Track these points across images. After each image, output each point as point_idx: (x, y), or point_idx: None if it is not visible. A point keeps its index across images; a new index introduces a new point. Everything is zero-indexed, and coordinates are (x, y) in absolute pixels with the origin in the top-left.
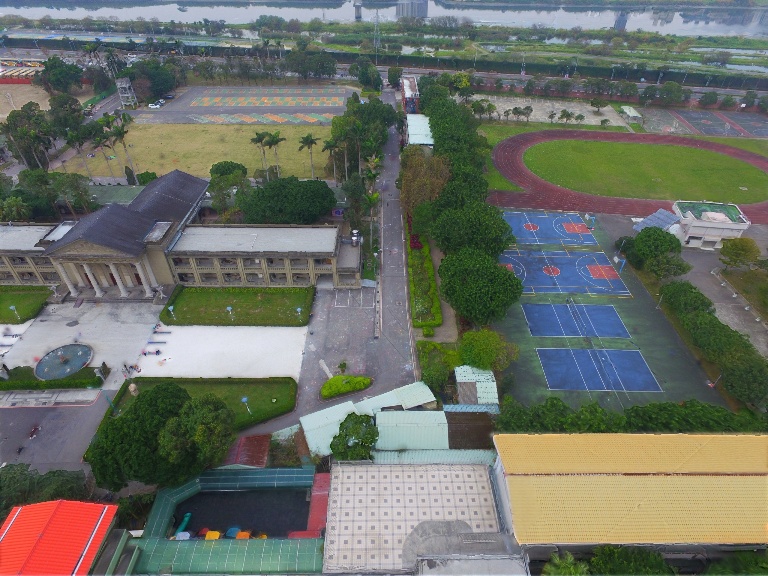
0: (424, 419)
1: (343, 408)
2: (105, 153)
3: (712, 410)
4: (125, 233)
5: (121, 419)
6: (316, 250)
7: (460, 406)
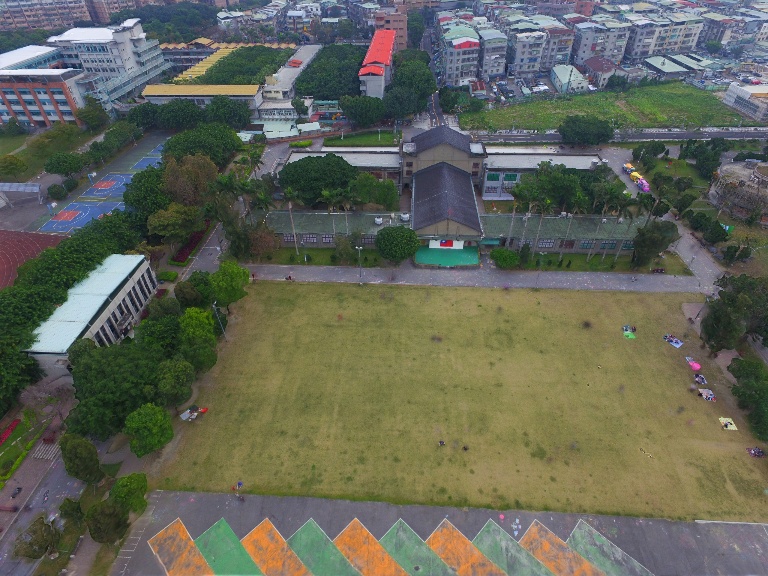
0: (272, 127)
1: (303, 128)
2: (658, 348)
3: (172, 107)
4: (425, 138)
5: (375, 98)
6: (303, 155)
7: (255, 133)
